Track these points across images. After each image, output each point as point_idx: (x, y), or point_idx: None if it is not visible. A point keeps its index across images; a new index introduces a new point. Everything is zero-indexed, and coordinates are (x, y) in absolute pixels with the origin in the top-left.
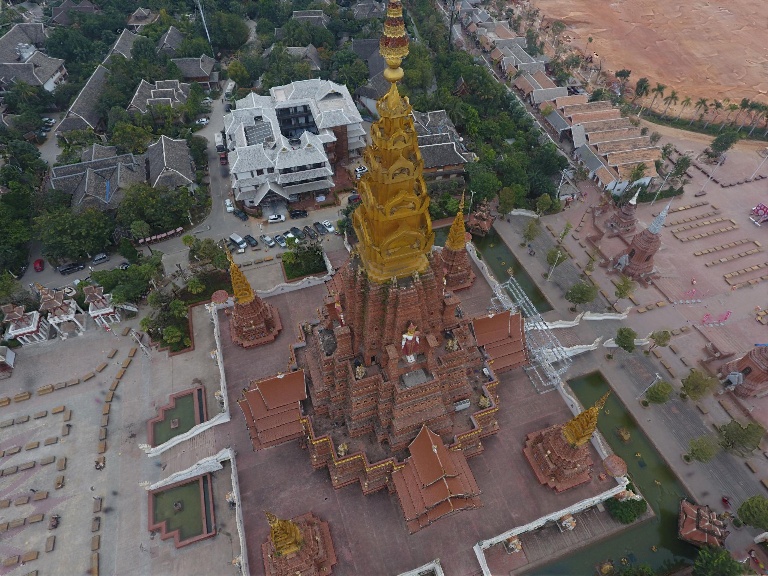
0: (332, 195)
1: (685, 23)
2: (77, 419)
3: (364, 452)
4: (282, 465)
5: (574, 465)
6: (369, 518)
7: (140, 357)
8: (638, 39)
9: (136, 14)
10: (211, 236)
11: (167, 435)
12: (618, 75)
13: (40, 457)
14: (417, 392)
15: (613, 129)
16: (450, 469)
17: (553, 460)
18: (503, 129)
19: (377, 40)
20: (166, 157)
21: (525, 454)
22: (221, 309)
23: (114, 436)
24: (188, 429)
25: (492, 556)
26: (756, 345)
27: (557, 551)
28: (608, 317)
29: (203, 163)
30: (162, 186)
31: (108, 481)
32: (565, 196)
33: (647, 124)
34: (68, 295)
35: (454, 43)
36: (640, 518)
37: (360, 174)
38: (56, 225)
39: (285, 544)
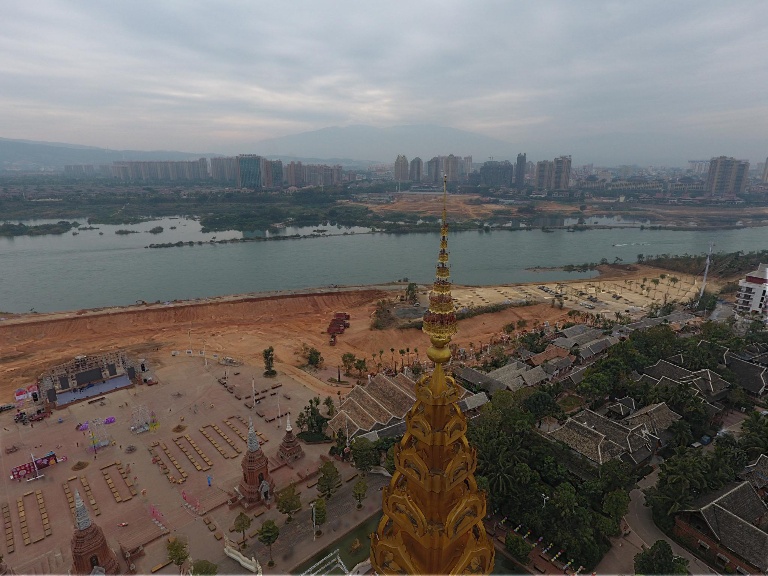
0: None
1: None
2: None
3: None
4: None
5: None
6: None
7: None
8: None
9: None
10: None
11: None
12: None
13: None
14: None
15: None
16: None
17: None
18: None
19: None
20: None
21: None
22: None
23: None
24: None
25: None
26: (210, 485)
27: None
28: None
29: None
30: None
31: None
32: None
33: None
34: None
35: None
36: None
37: None
38: None
39: None
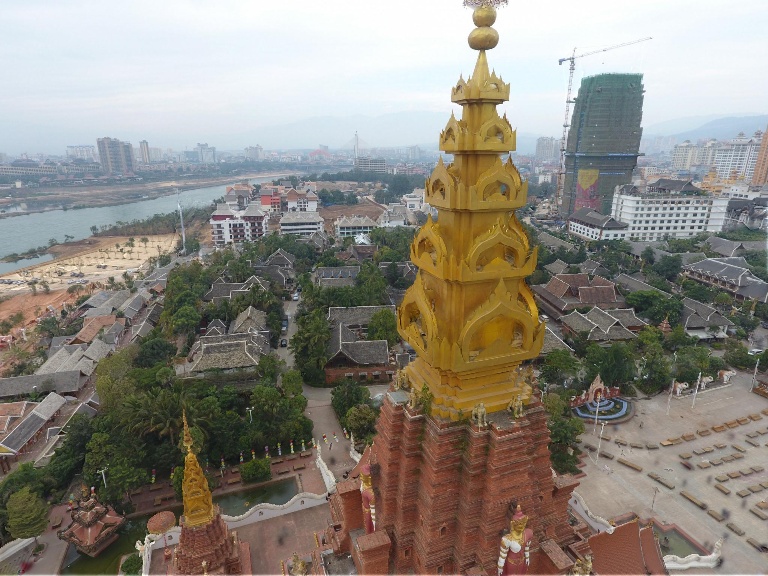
0: None
1: None
2: None
3: None
4: None
5: None
6: None
7: None
8: None
9: None
10: None
11: None
12: None
13: None
14: None
15: None
16: None
17: None
18: None
19: None
20: None
21: None
22: None
23: None
24: None
25: None
26: None
27: None
28: None
29: None
30: None
31: None
32: None
33: None
34: None
35: None
36: None
37: None
38: None
39: None
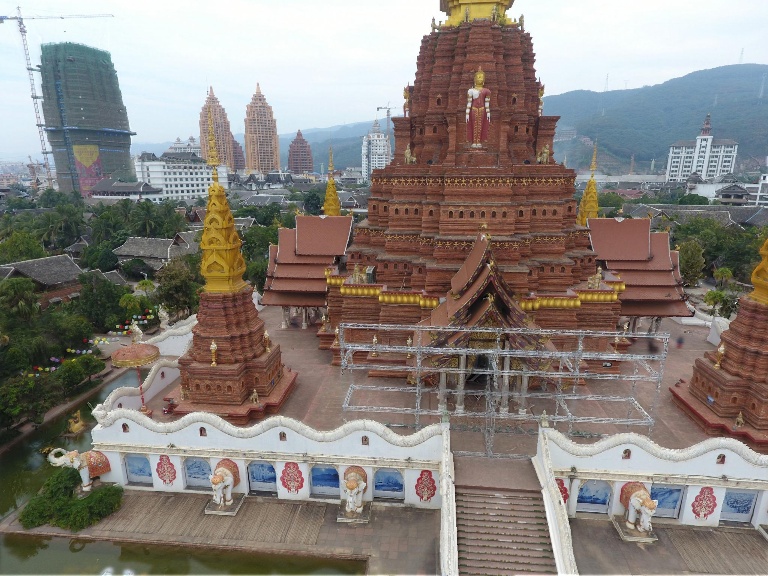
0: None
1: None
2: None
3: None
4: None
5: None
6: None
7: None
8: None
9: None
10: None
11: None
12: None
13: None
14: None
15: None
16: (304, 246)
17: None
18: None
19: None
20: None
21: None
22: None
23: None
24: None
25: None
26: None
27: None
28: None
29: None
30: None
31: None
32: None
33: None
34: None
35: None
36: None
37: None
38: (690, 225)
39: None
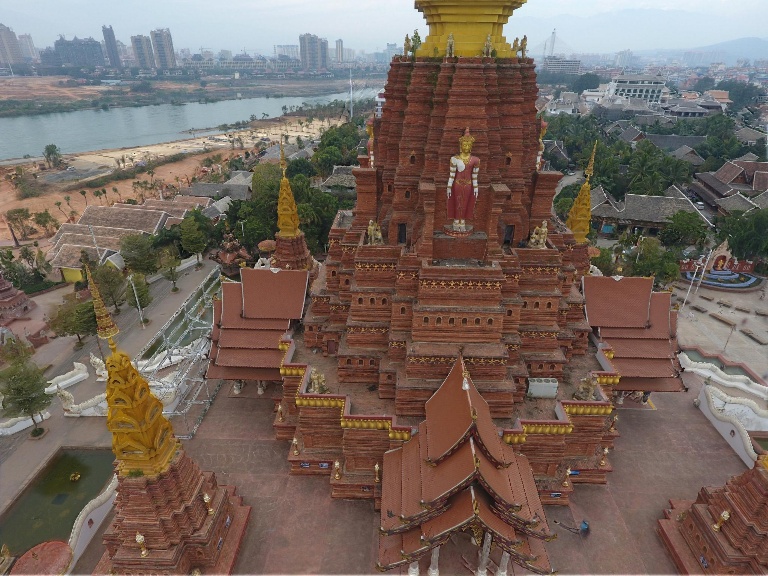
0: None
1: None
2: None
3: None
4: None
5: None
6: None
7: None
8: None
9: None
10: None
11: None
12: None
13: None
14: None
15: None
16: None
17: None
18: None
19: None
20: None
21: None
22: None
23: None
24: None
25: None
26: None
27: None
28: None
29: None
30: None
31: None
32: None
33: None
34: None
35: None
36: None
37: None
38: None
39: None
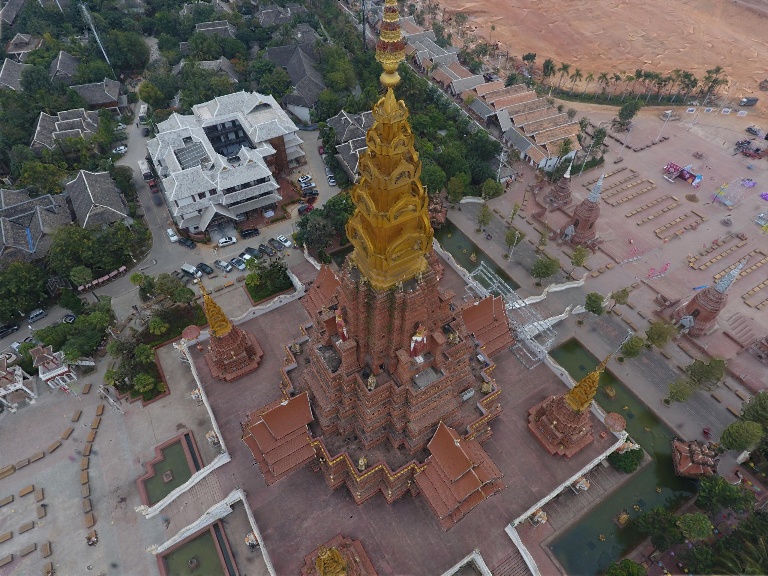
0: (280, 209)
1: (570, 5)
2: (52, 496)
3: (384, 461)
4: (298, 494)
5: (579, 430)
6: (399, 526)
7: (110, 414)
8: (532, 23)
9: (15, 41)
10: (159, 270)
11: (162, 490)
12: (525, 59)
13: (17, 548)
14: (431, 391)
15: (534, 110)
16: (473, 459)
17: (560, 429)
18: (434, 122)
19: (292, 46)
20: (92, 193)
21: (531, 429)
22: (192, 345)
23: (101, 505)
24: (184, 479)
25: (521, 533)
26: (694, 289)
27: (577, 513)
28: (569, 286)
29: (132, 194)
30: (95, 225)
31: (106, 555)
32: (504, 178)
33: (559, 102)
34: (7, 362)
35: (367, 42)
36: (641, 465)
37: (304, 183)
38: None
39: (334, 573)
